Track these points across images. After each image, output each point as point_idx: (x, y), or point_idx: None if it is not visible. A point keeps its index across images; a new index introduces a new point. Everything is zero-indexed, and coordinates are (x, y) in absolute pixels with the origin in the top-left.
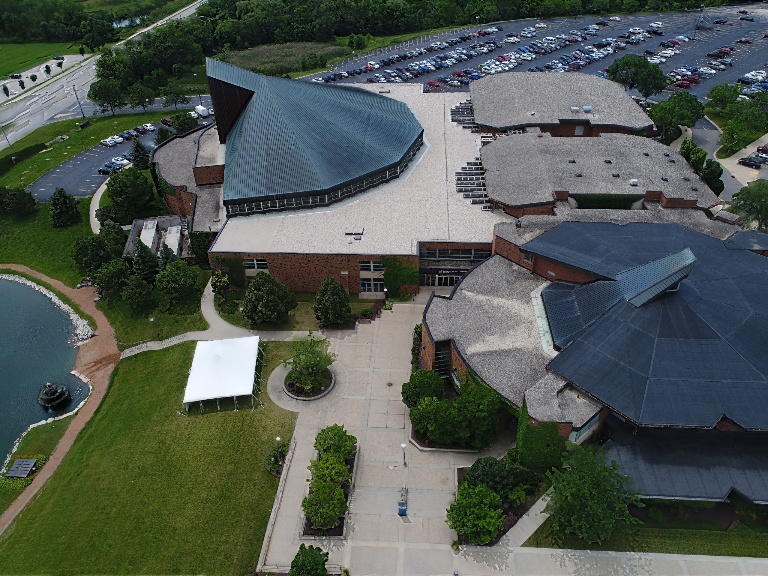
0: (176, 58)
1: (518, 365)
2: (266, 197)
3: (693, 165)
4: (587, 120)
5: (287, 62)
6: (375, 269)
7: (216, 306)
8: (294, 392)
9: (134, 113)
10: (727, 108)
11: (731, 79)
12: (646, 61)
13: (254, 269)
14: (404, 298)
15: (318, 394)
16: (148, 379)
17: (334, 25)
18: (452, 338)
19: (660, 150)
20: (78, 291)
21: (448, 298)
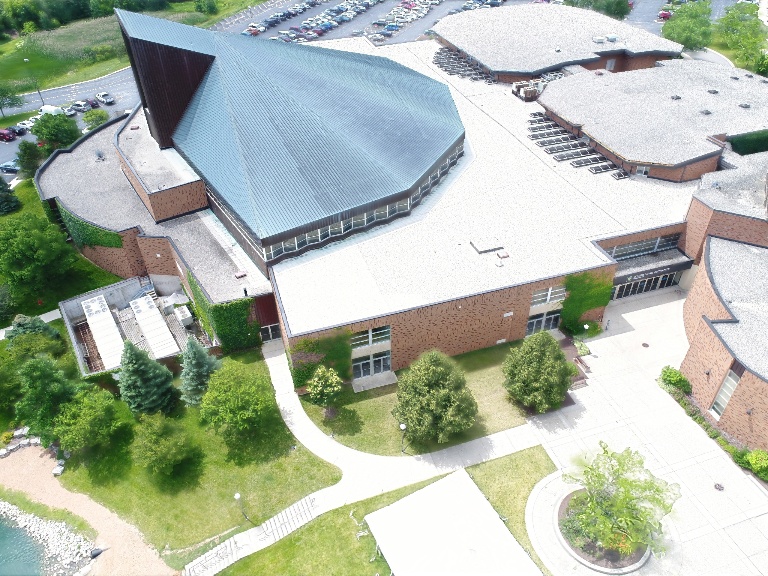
0: None
1: None
2: (326, 219)
3: None
4: (623, 50)
5: None
6: (552, 298)
7: (321, 426)
8: (603, 561)
9: None
10: (712, 25)
11: (659, 1)
12: None
13: (366, 345)
14: (596, 330)
15: (643, 550)
16: None
17: None
18: None
19: (736, 72)
20: (6, 463)
21: (734, 321)
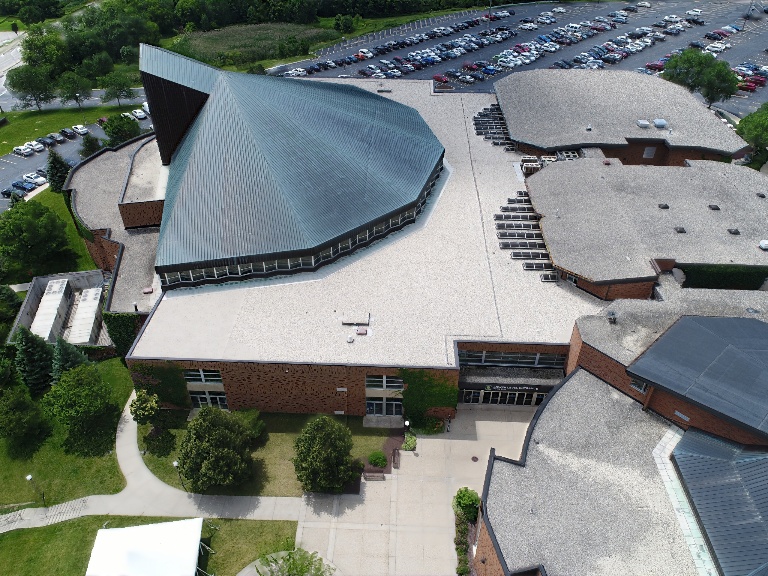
0: (125, 39)
1: None
2: (222, 261)
3: None
4: (663, 139)
5: (261, 47)
6: (390, 385)
7: (140, 441)
8: None
9: (66, 109)
10: None
11: None
12: (713, 58)
13: (200, 382)
14: (434, 429)
15: None
16: None
17: (317, 4)
18: (540, 562)
19: None
20: None
21: (519, 464)
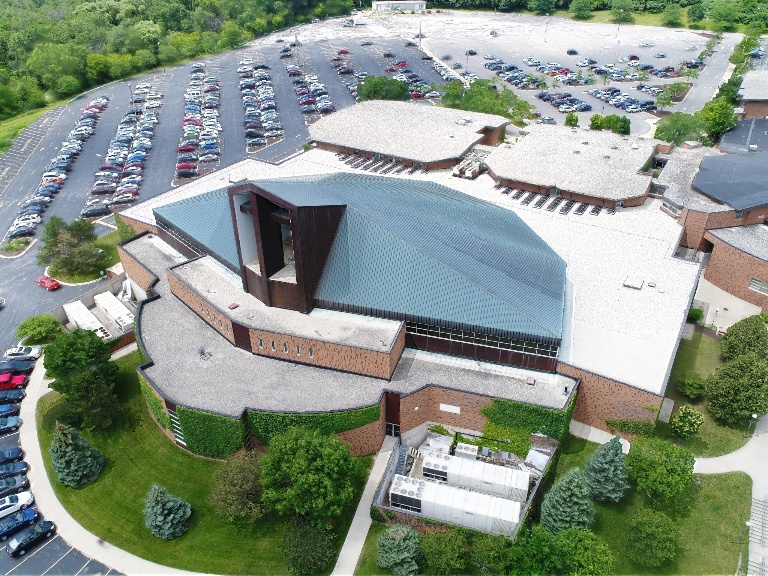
0: None
1: None
2: None
3: (598, 128)
4: (486, 127)
5: None
6: None
7: None
8: None
9: None
10: None
11: None
12: None
13: None
14: None
15: None
16: None
17: None
18: None
19: (563, 127)
20: None
21: None
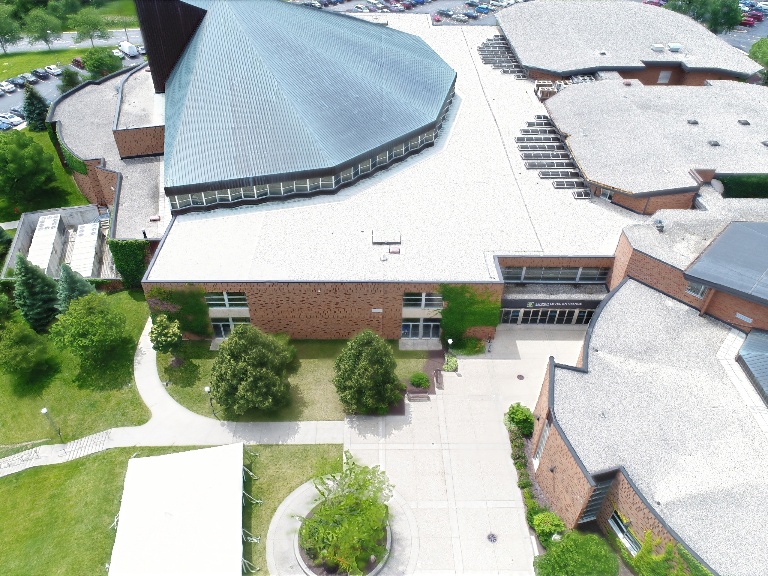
0: None
1: (767, 529)
2: (236, 181)
3: None
4: (679, 62)
5: None
6: (428, 304)
7: (161, 372)
8: (320, 569)
9: (34, 51)
10: None
11: None
12: None
13: (224, 307)
14: (475, 349)
15: (366, 572)
16: (37, 536)
17: None
18: (619, 464)
19: None
20: None
21: (581, 370)
